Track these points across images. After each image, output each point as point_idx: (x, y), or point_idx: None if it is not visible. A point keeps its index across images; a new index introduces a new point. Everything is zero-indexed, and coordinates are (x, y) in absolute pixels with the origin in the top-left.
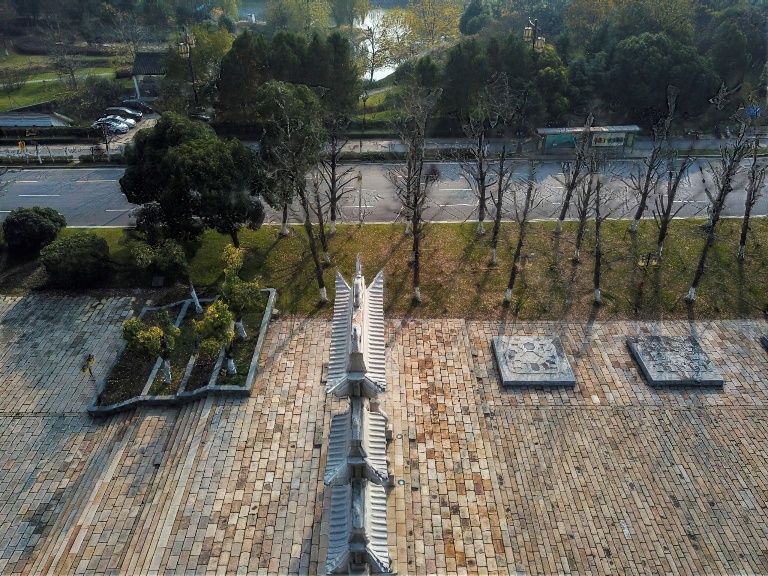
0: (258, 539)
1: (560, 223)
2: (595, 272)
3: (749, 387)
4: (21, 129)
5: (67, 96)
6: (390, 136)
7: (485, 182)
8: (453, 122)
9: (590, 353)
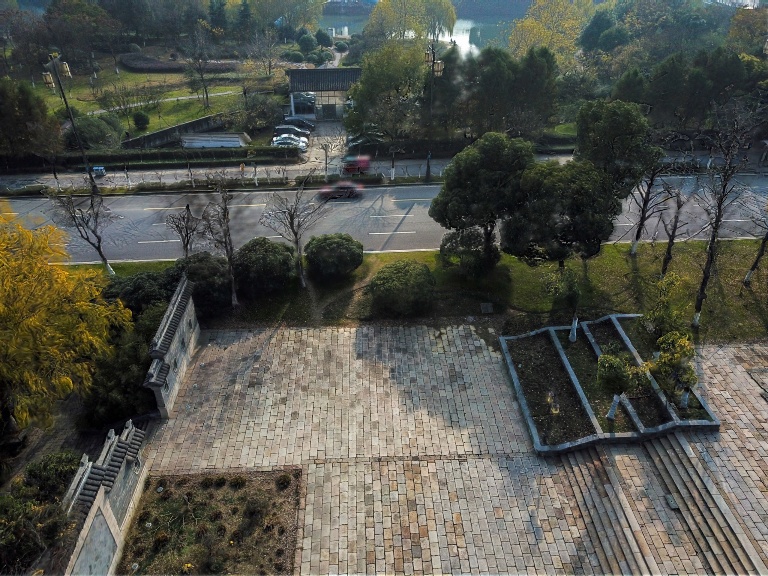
0: None
1: None
2: None
3: None
4: (216, 150)
5: (241, 115)
6: None
7: None
8: None
9: None
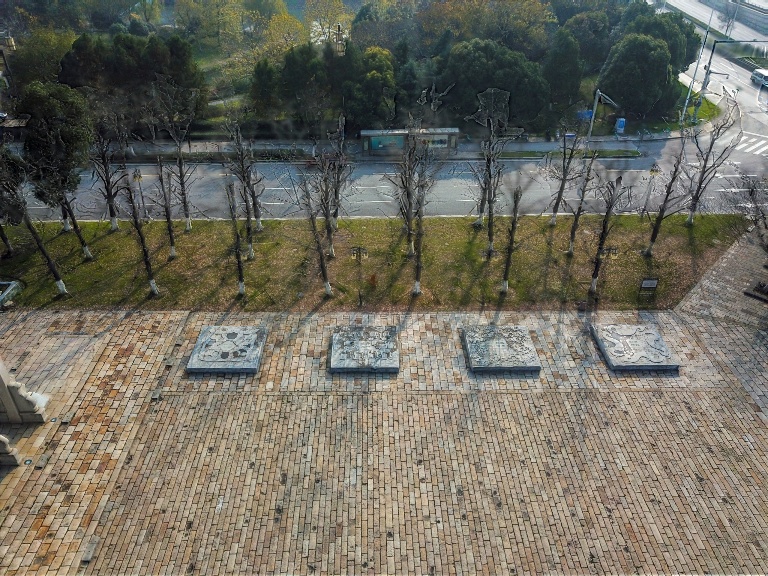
0: None
1: (334, 220)
2: (321, 266)
3: (423, 374)
4: None
5: None
6: None
7: None
8: (296, 124)
9: (292, 342)
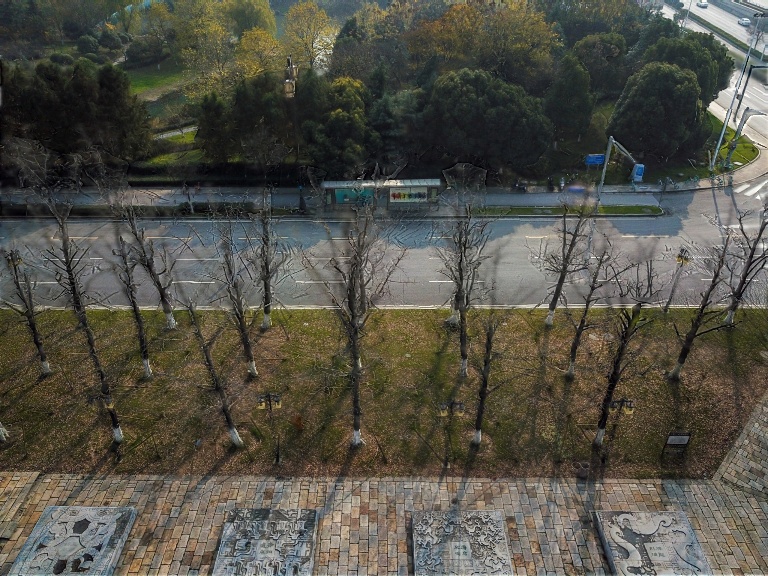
0: None
1: (266, 317)
2: (222, 409)
3: None
4: None
5: None
6: (172, 184)
7: (156, 269)
8: (252, 167)
9: (166, 536)
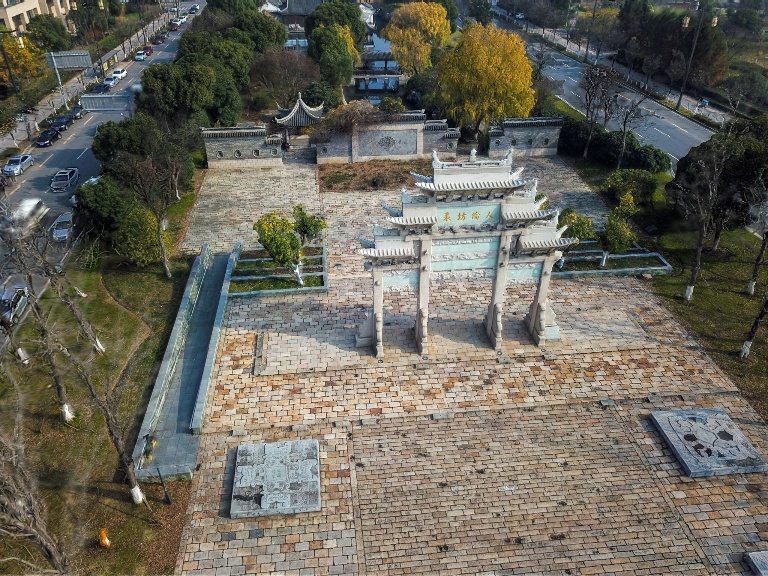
0: (436, 301)
1: None
2: None
3: None
4: None
5: None
6: None
7: None
8: None
9: (766, 501)
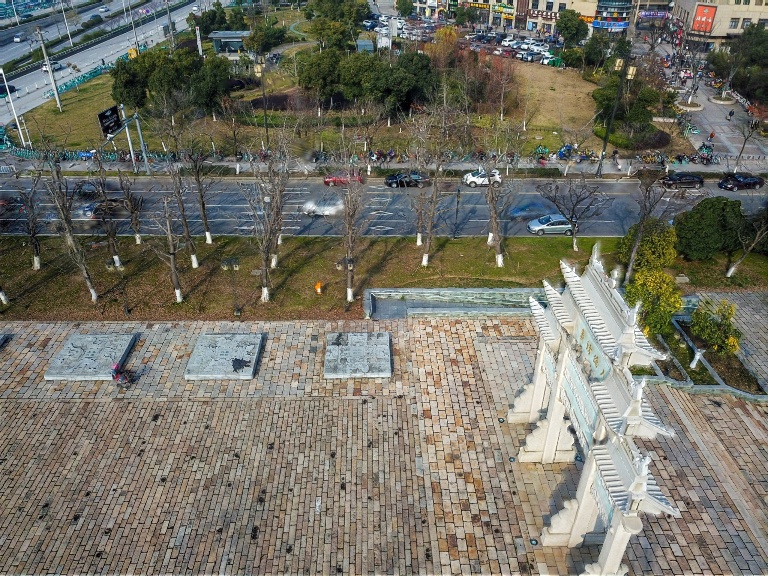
0: None
1: None
2: None
3: None
4: None
5: None
6: None
7: None
8: None
9: None
